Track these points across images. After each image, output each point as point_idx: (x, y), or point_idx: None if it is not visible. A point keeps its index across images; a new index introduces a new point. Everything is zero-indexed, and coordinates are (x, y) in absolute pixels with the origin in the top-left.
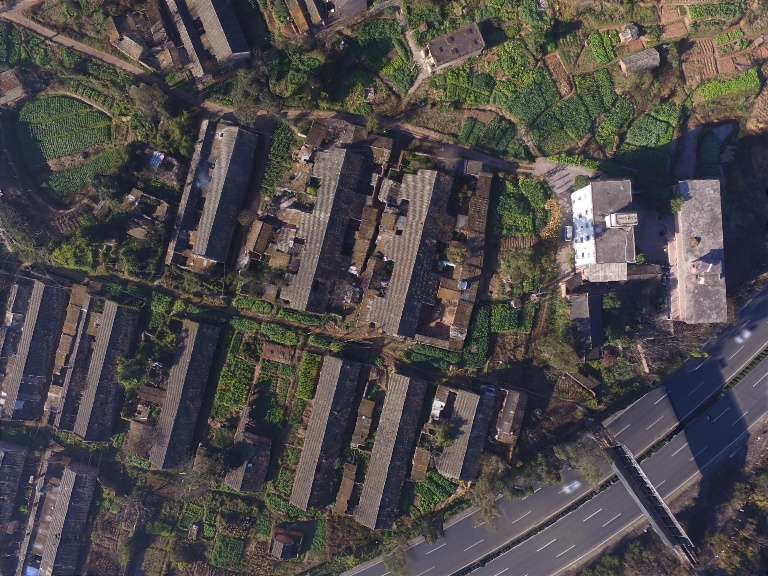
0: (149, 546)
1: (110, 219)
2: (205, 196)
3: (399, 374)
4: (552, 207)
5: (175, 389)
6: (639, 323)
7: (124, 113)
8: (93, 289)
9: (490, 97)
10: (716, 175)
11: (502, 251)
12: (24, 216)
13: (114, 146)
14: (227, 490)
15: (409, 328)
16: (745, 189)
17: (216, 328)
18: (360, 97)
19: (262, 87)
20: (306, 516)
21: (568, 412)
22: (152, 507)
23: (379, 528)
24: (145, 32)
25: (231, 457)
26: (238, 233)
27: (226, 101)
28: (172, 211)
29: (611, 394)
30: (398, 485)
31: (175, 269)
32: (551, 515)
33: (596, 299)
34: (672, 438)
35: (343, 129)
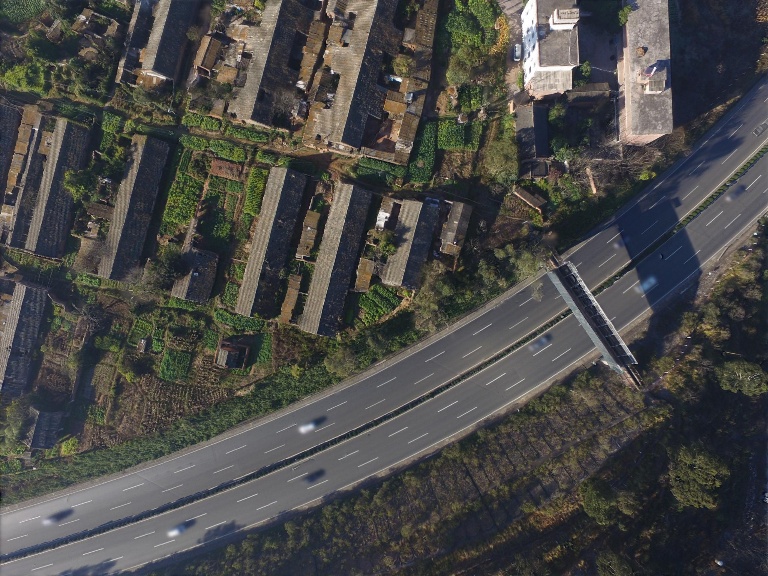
0: (99, 362)
1: (62, 41)
2: (155, 15)
3: (344, 183)
4: (501, 26)
5: (123, 202)
6: (585, 136)
7: None
8: (44, 109)
9: None
10: (671, 8)
11: None
12: None
13: None
14: (175, 305)
15: (354, 138)
16: (700, 21)
17: (164, 143)
18: None
19: None
20: (252, 330)
21: (514, 229)
22: (100, 318)
23: (322, 334)
24: None
25: (176, 262)
26: (188, 54)
27: None
28: (123, 32)
29: (557, 212)
30: (342, 294)
31: (125, 87)
32: (501, 350)
33: (541, 110)
34: (624, 276)
35: None
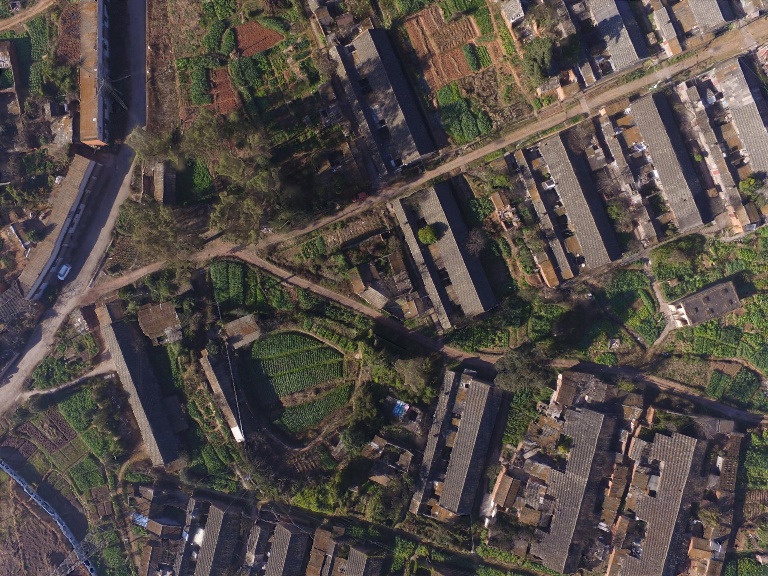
0: None
1: (349, 462)
2: (449, 445)
3: None
4: None
5: None
6: None
7: None
8: (336, 534)
9: (737, 349)
10: None
11: (747, 504)
12: (270, 466)
13: (346, 382)
14: None
15: None
16: None
17: None
18: (604, 346)
19: (538, 372)
20: None
21: None
22: None
23: None
24: (390, 283)
25: None
26: (480, 480)
27: (467, 347)
28: (413, 457)
29: None
30: None
31: (420, 518)
32: None
33: None
34: None
35: (593, 386)
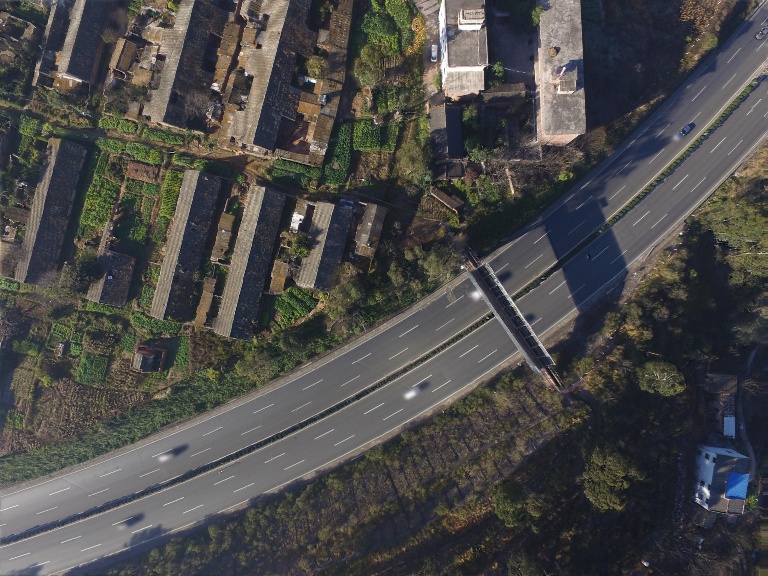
0: (18, 366)
1: None
2: None
3: None
4: (418, 26)
5: (38, 205)
6: (499, 137)
7: None
8: None
9: None
10: (595, 8)
11: None
12: None
13: None
14: (92, 308)
15: (267, 140)
16: (623, 20)
17: (80, 146)
18: None
19: None
20: (169, 333)
21: (431, 231)
22: (16, 322)
23: (235, 337)
24: None
25: (88, 266)
26: (106, 56)
27: None
28: (41, 35)
29: (475, 213)
30: (256, 296)
31: (41, 90)
32: (428, 351)
33: (455, 111)
34: (550, 276)
35: None
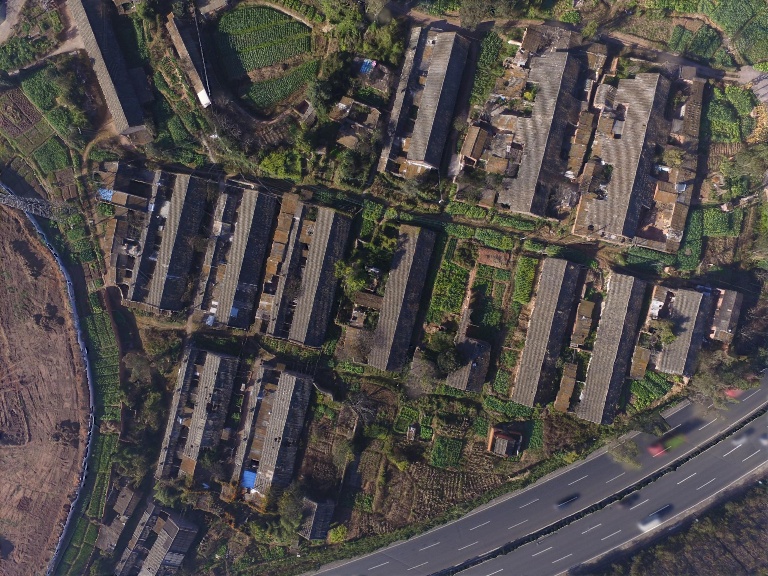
0: (364, 449)
1: (317, 129)
2: (416, 104)
3: (621, 274)
4: (759, 114)
5: (395, 293)
6: None
7: (335, 20)
8: (304, 197)
9: (698, 5)
10: None
11: (711, 157)
12: None
13: (314, 58)
14: (444, 392)
15: (630, 229)
16: None
17: (433, 233)
18: (568, 5)
19: None
20: (523, 416)
21: None
22: None
23: (604, 423)
24: None
25: (460, 355)
26: (448, 141)
27: (433, 10)
28: (381, 120)
29: None
30: (620, 382)
31: (388, 176)
32: (736, 422)
33: None
34: None
35: (558, 35)
